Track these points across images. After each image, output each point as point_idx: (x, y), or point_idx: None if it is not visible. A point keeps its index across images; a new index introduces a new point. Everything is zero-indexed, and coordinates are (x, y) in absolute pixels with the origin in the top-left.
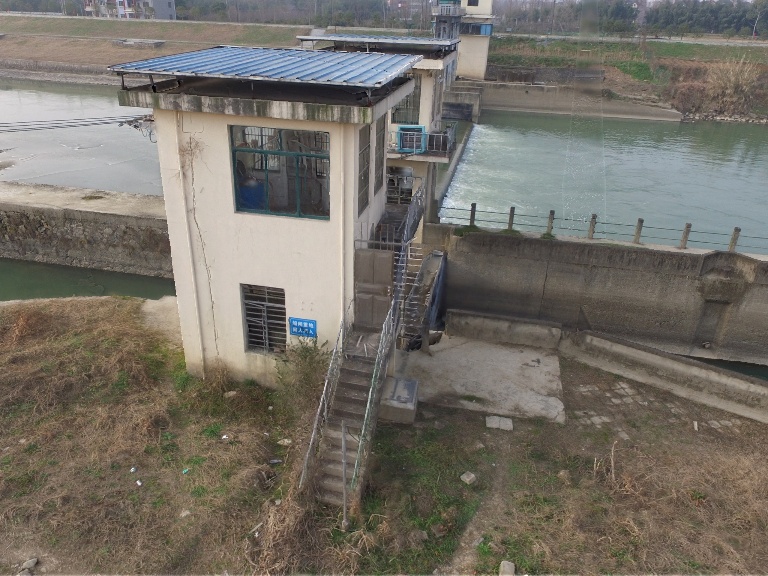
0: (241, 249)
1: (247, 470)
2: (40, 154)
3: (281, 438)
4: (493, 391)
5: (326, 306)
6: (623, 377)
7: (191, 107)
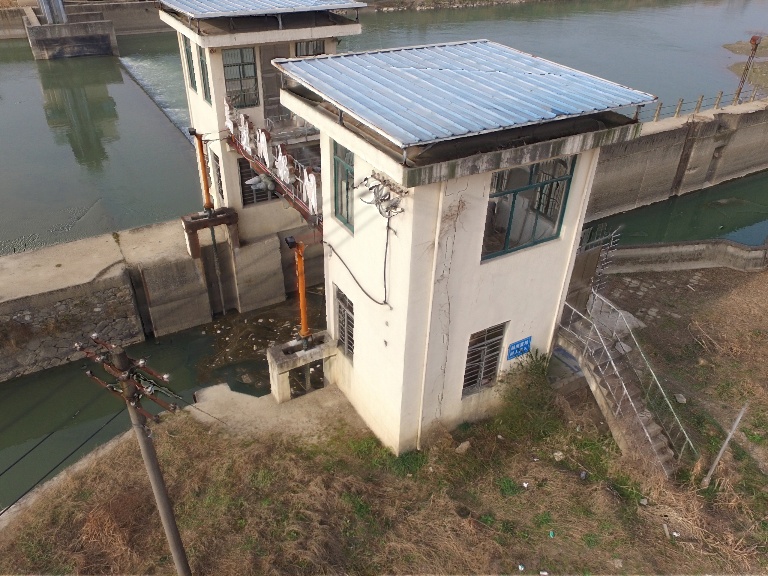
0: (480, 300)
1: (601, 496)
2: None
3: (552, 455)
4: None
5: (543, 319)
6: (622, 274)
7: (489, 167)
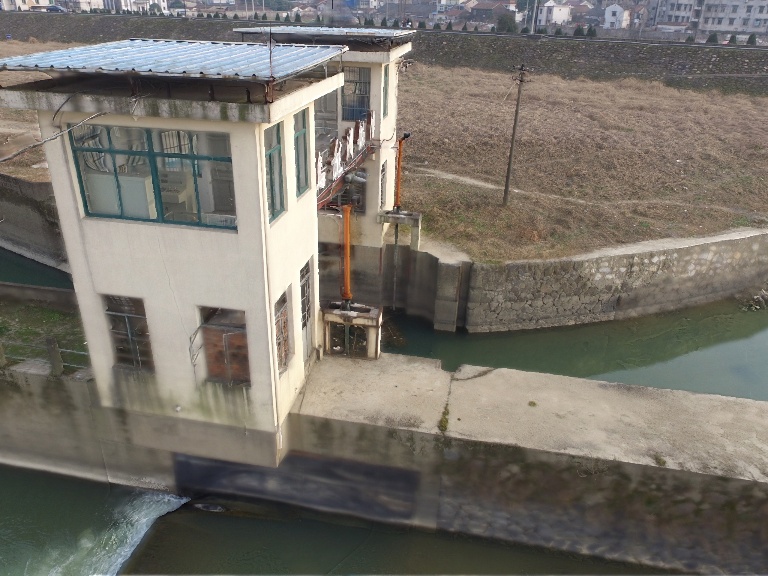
0: None
1: None
2: None
3: None
4: None
5: None
6: None
7: None
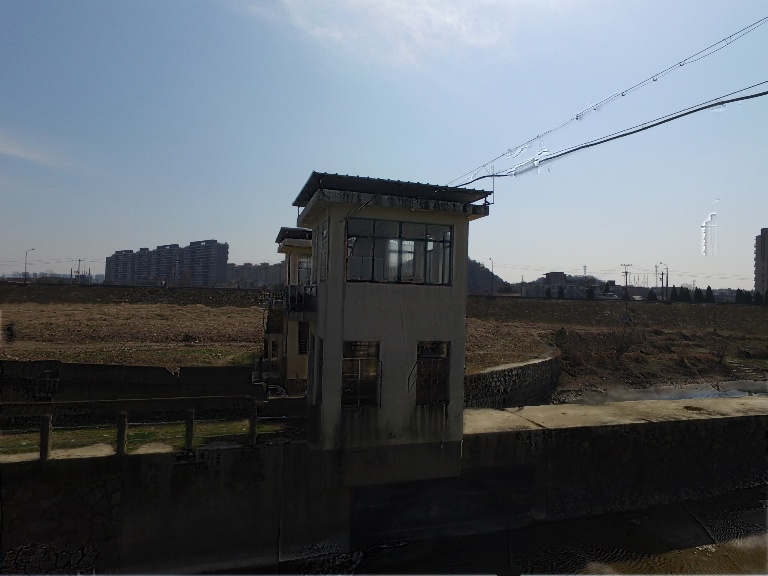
0: None
1: None
2: None
3: None
4: None
5: None
6: None
7: None
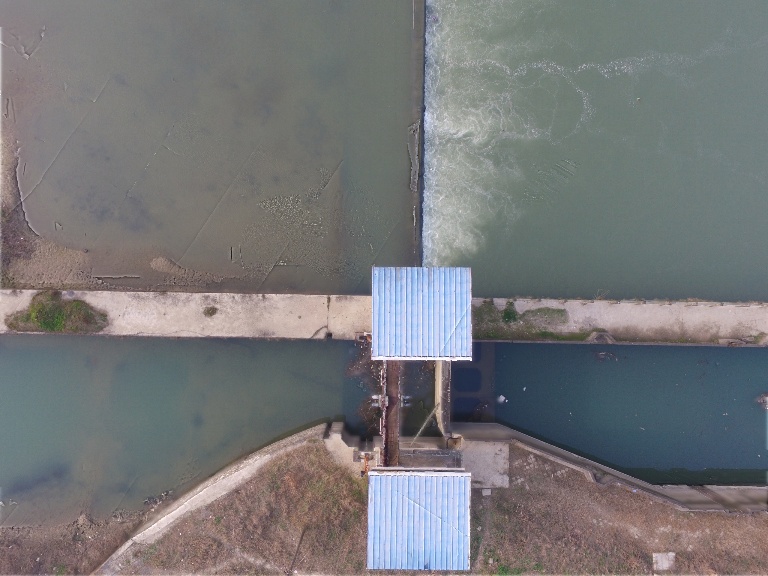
0: None
1: None
2: (8, 92)
3: None
4: (484, 476)
5: None
6: (532, 452)
7: None
